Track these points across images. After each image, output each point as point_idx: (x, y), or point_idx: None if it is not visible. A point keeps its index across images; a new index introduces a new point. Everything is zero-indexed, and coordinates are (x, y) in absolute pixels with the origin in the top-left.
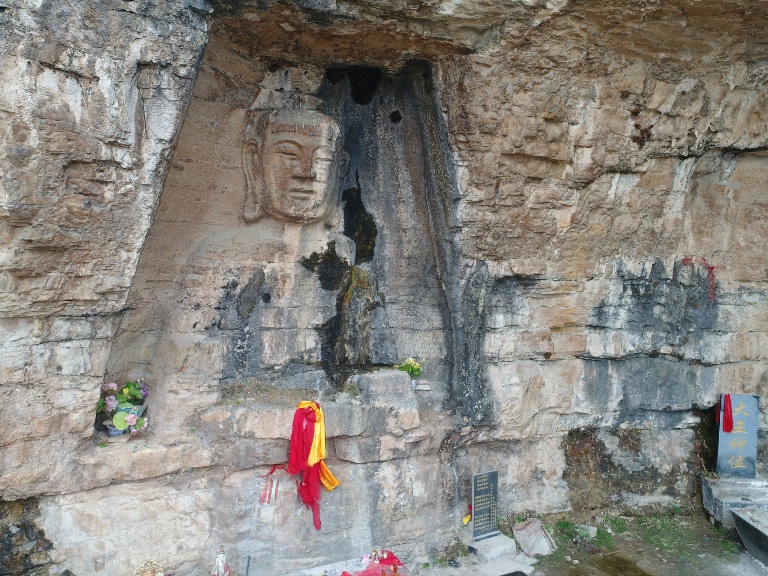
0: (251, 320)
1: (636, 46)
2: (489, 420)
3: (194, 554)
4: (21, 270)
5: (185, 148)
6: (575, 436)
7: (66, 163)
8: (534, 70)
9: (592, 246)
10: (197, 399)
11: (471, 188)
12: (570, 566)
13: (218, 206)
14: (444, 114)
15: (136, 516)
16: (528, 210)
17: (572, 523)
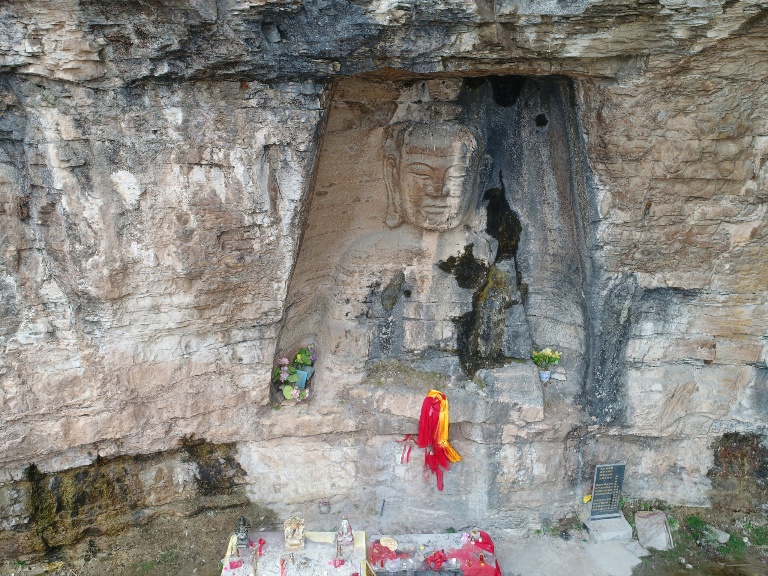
0: (394, 311)
1: None
2: (620, 422)
3: (344, 491)
4: (201, 306)
5: (327, 176)
6: (732, 438)
7: (219, 233)
8: (698, 92)
9: None
10: (346, 378)
11: (614, 210)
12: (680, 569)
13: (364, 213)
14: (585, 135)
15: (301, 460)
16: (690, 226)
17: (705, 522)
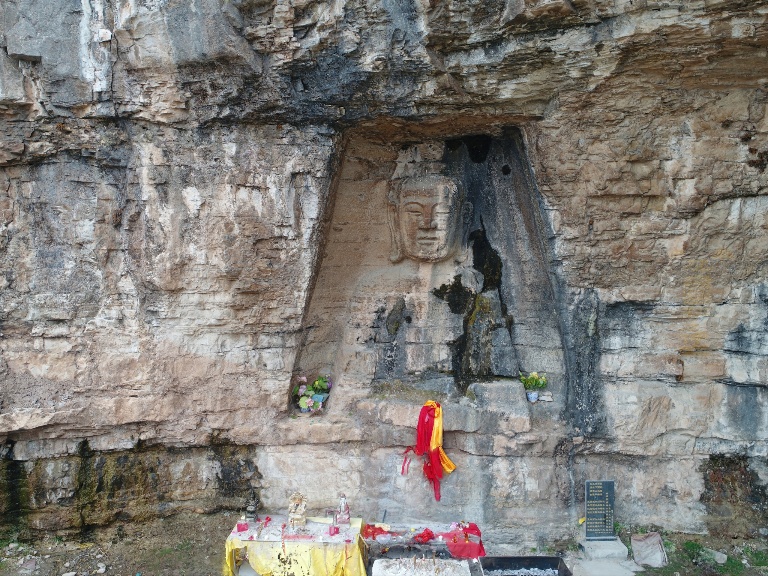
0: (398, 336)
1: (722, 80)
2: (602, 433)
3: (349, 501)
4: (237, 306)
5: (342, 216)
6: (719, 461)
7: (255, 241)
8: (605, 123)
9: (718, 271)
10: (354, 392)
11: (565, 227)
12: None
13: (373, 252)
14: (533, 168)
15: (311, 467)
16: (631, 242)
17: (702, 546)
